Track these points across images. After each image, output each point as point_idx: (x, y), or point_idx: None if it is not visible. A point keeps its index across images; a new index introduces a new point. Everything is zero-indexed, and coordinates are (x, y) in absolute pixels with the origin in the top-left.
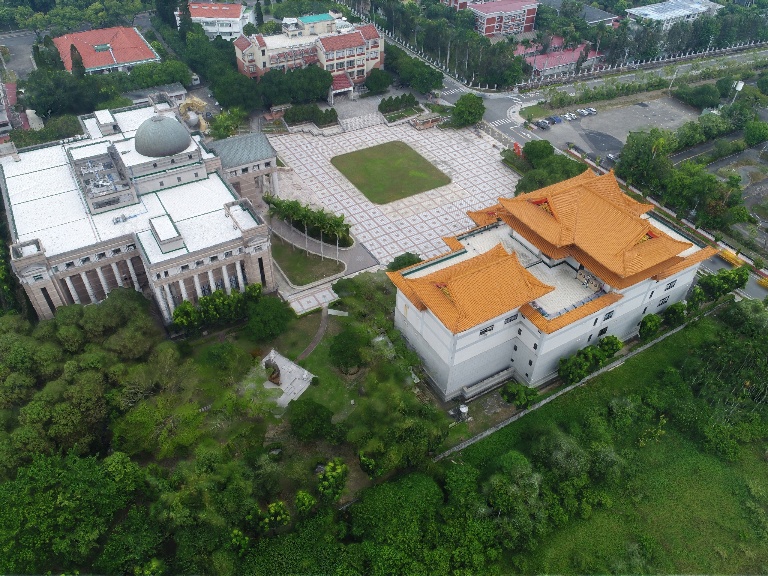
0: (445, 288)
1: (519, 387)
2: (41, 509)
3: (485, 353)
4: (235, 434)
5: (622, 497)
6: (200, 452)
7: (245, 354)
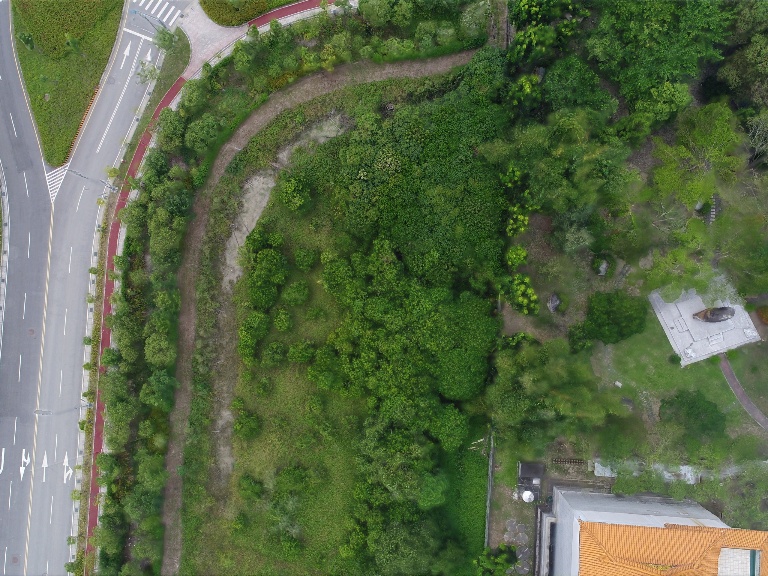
0: (663, 570)
1: (500, 570)
2: (652, 7)
3: (570, 572)
4: (639, 225)
5: (341, 572)
6: (630, 175)
7: (759, 290)
